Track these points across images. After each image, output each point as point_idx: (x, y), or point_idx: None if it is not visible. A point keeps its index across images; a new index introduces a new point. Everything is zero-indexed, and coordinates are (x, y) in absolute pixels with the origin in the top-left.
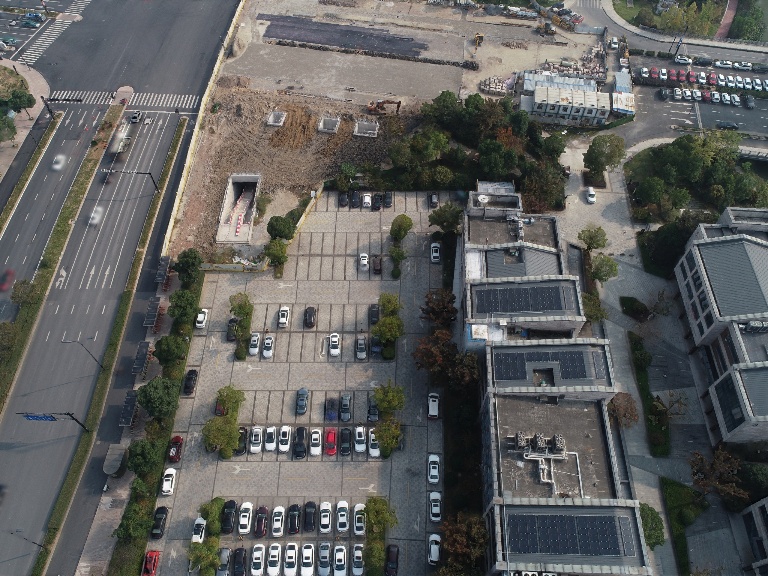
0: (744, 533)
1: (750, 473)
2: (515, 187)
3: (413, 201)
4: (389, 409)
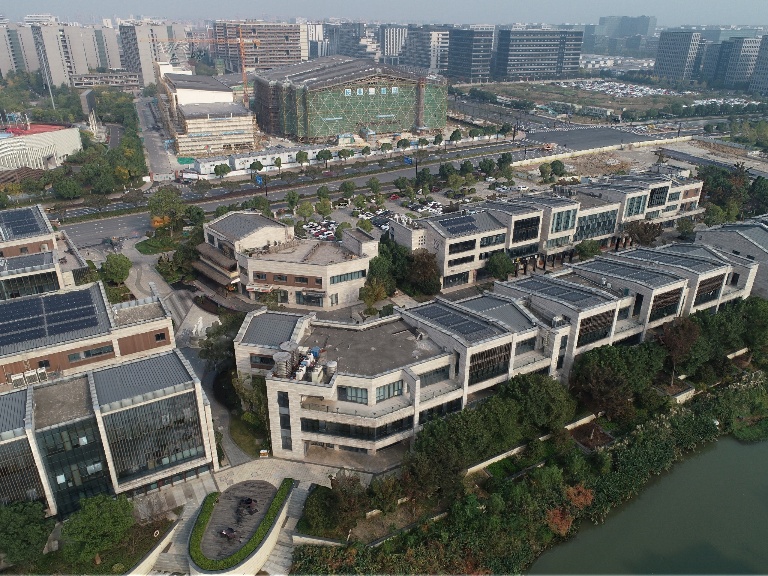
0: None
1: None
2: None
3: None
4: None
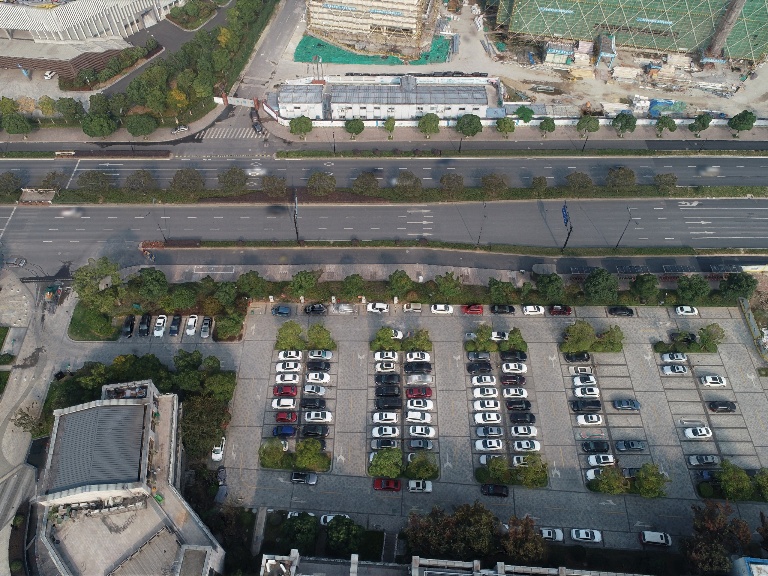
0: None
1: None
2: None
3: None
4: (639, 483)
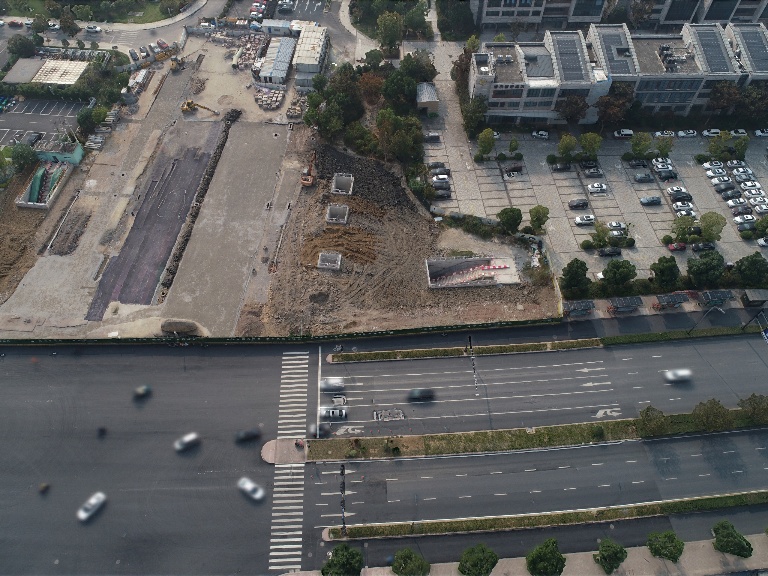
0: (638, 31)
1: (622, 11)
2: (424, 82)
3: (433, 152)
4: None
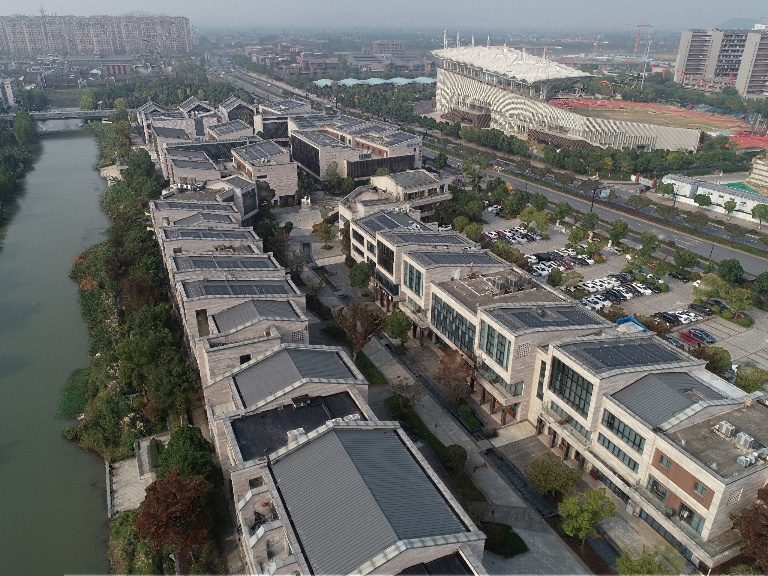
0: None
1: None
2: None
3: None
4: None
